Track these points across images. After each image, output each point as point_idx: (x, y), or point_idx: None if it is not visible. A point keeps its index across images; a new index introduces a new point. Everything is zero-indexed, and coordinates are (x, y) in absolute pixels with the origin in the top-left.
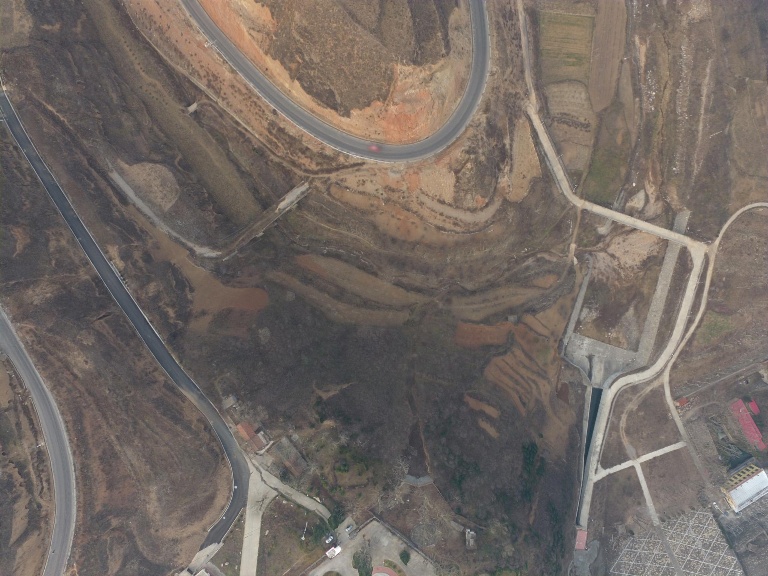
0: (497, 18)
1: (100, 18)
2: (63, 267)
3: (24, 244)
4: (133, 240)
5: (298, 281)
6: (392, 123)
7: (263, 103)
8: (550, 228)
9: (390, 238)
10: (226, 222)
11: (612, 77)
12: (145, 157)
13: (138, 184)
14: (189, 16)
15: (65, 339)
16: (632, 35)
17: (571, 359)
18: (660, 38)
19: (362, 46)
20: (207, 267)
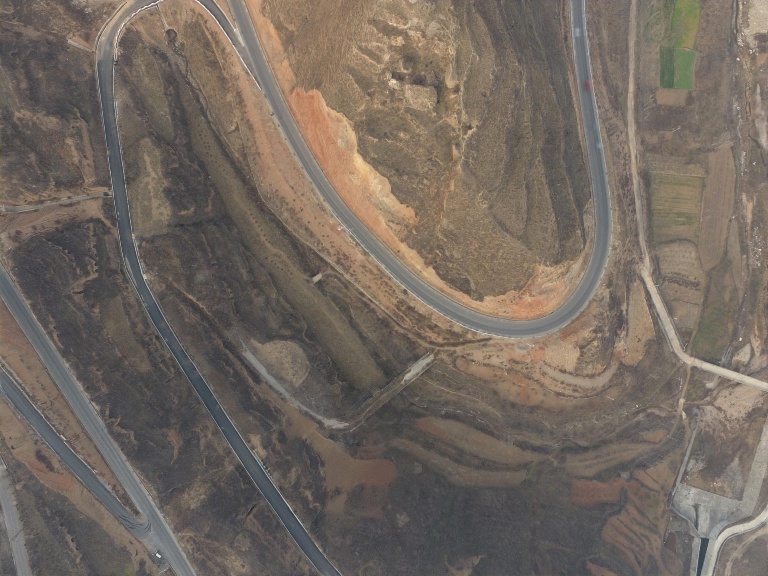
0: (618, 191)
1: (227, 192)
2: (212, 464)
3: (179, 448)
4: (272, 425)
5: (421, 447)
6: (524, 307)
7: (394, 283)
8: (661, 385)
9: (510, 403)
10: (350, 390)
11: (721, 236)
12: (275, 333)
13: (270, 362)
14: (323, 200)
15: (223, 545)
16: (740, 193)
17: (678, 509)
18: (767, 195)
19: (508, 250)
20: (335, 439)
